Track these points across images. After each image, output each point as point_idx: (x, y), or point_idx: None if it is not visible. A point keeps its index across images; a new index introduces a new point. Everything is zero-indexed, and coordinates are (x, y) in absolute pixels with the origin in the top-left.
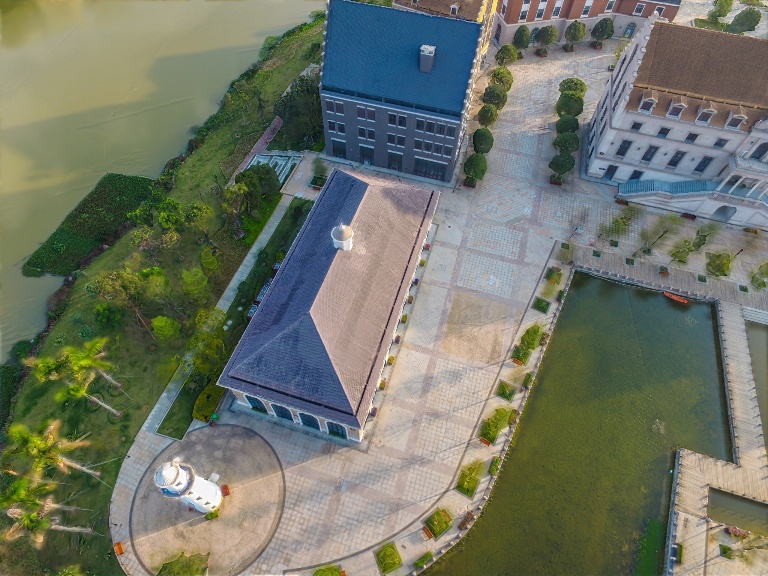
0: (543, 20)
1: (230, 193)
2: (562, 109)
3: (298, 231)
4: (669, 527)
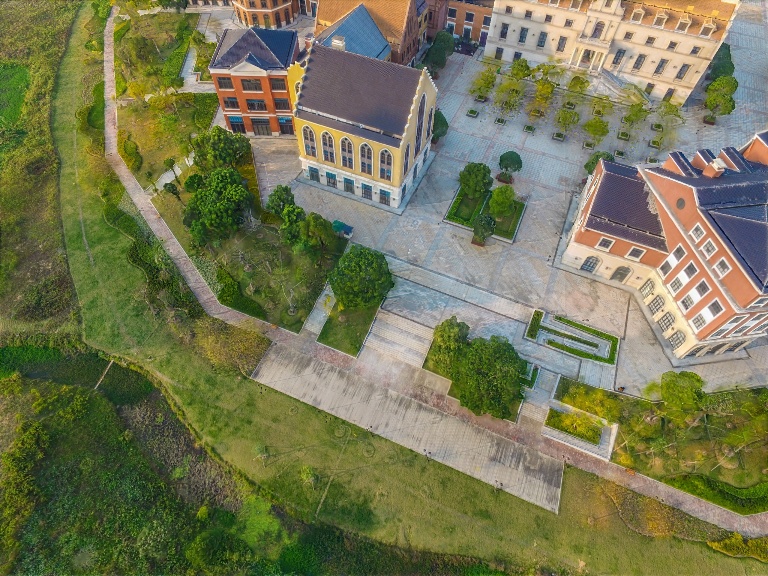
0: None
1: None
2: None
3: None
4: None
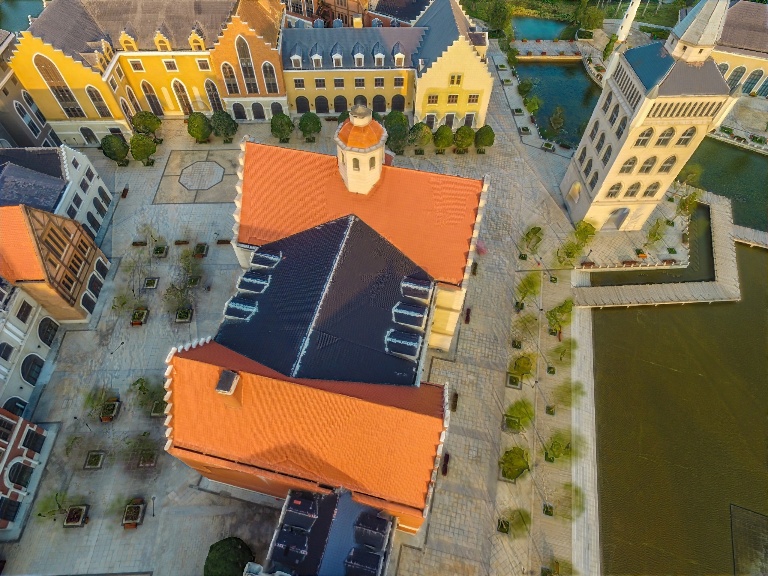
0: None
1: None
2: None
3: None
4: None
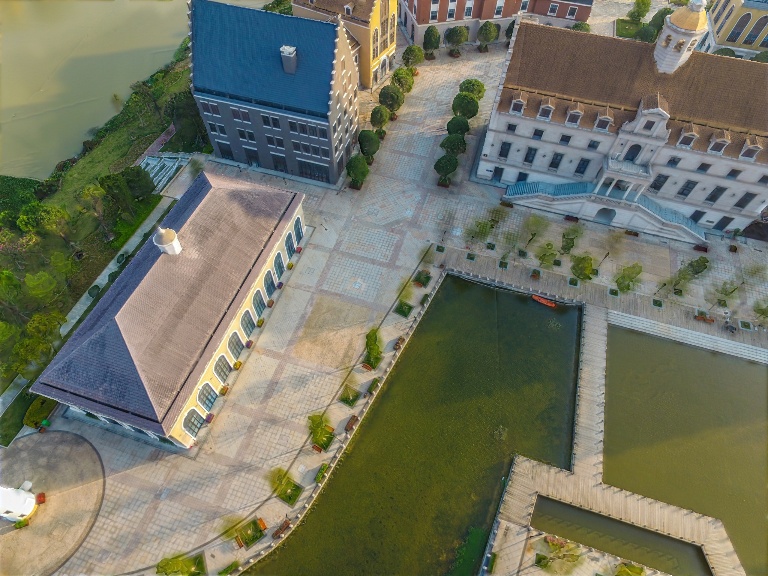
0: (456, 20)
1: (86, 196)
2: (457, 110)
3: None
4: (490, 536)
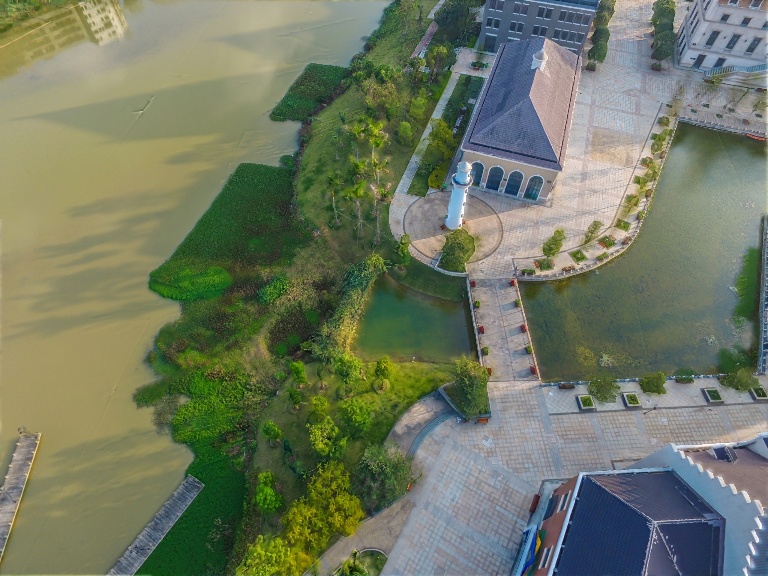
0: None
1: (436, 53)
2: (658, 19)
3: (470, 92)
4: (764, 250)
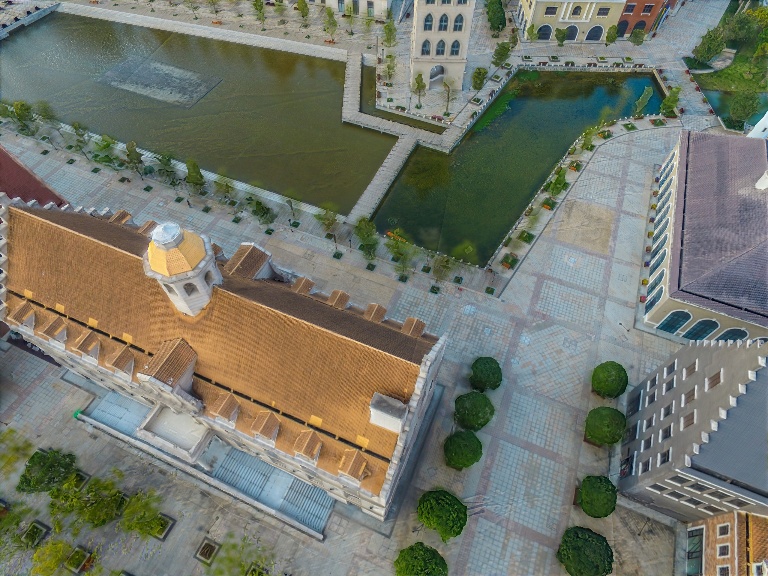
0: None
1: None
2: None
3: None
4: None
